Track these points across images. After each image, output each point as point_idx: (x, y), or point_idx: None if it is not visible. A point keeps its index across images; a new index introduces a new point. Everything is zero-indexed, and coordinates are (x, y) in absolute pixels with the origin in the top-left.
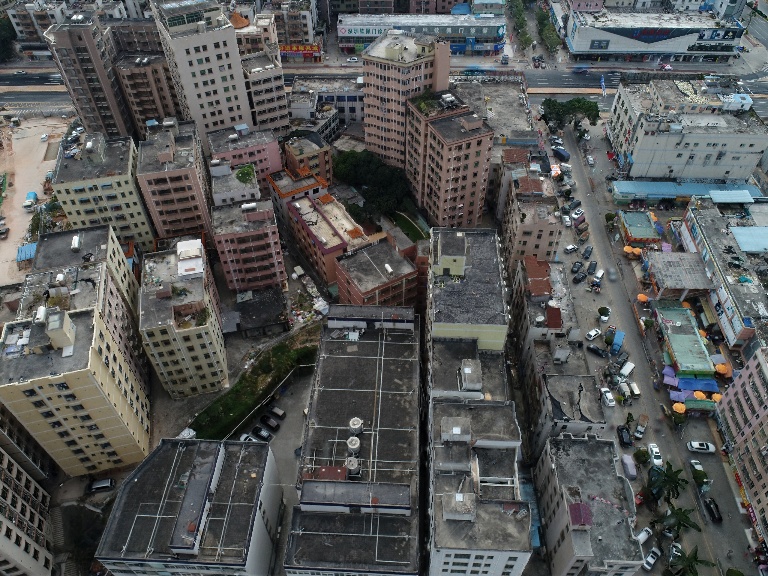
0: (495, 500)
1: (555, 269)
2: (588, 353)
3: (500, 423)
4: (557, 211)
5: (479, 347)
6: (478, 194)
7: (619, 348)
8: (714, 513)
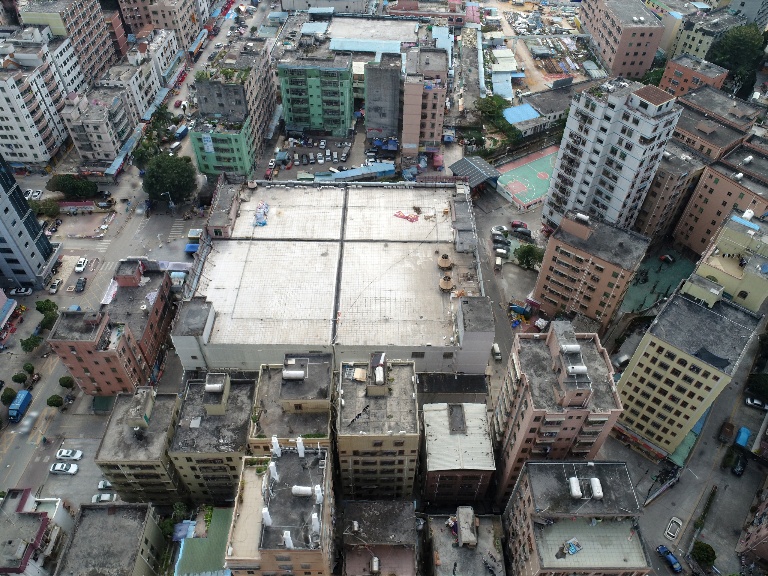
0: (3, 68)
1: None
2: None
3: (34, 51)
4: (177, 1)
5: (54, 33)
6: (148, 1)
7: None
8: None
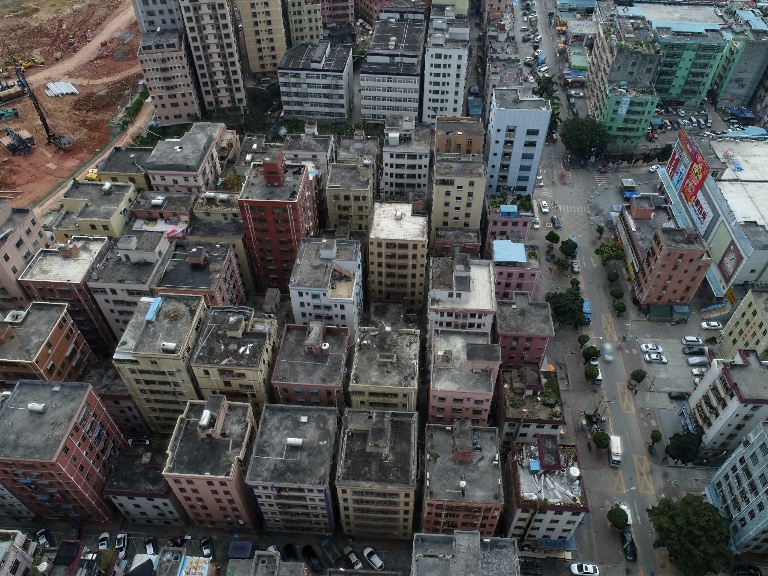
0: (454, 39)
1: (507, 15)
2: (524, 66)
3: (461, 26)
4: None
5: (455, 12)
6: None
7: (542, 62)
8: (575, 111)
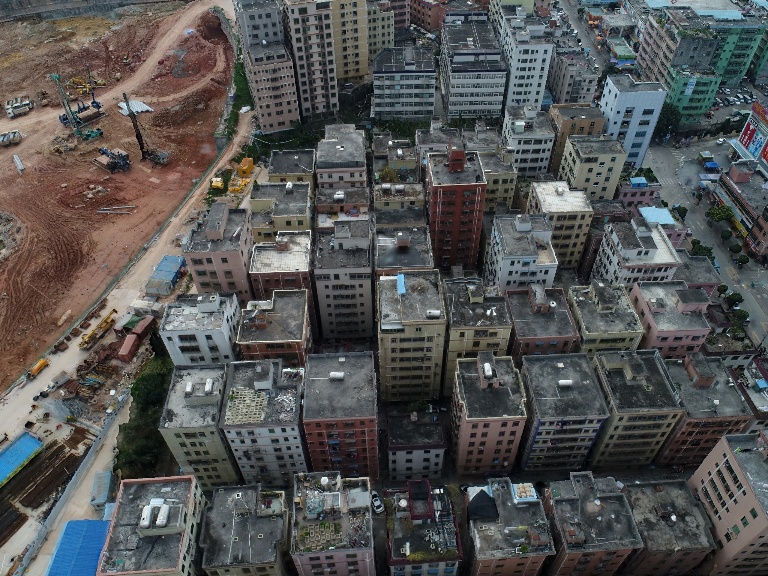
0: (537, 36)
1: (552, 13)
2: None
3: (535, 24)
4: None
5: None
6: None
7: (587, 54)
8: None
